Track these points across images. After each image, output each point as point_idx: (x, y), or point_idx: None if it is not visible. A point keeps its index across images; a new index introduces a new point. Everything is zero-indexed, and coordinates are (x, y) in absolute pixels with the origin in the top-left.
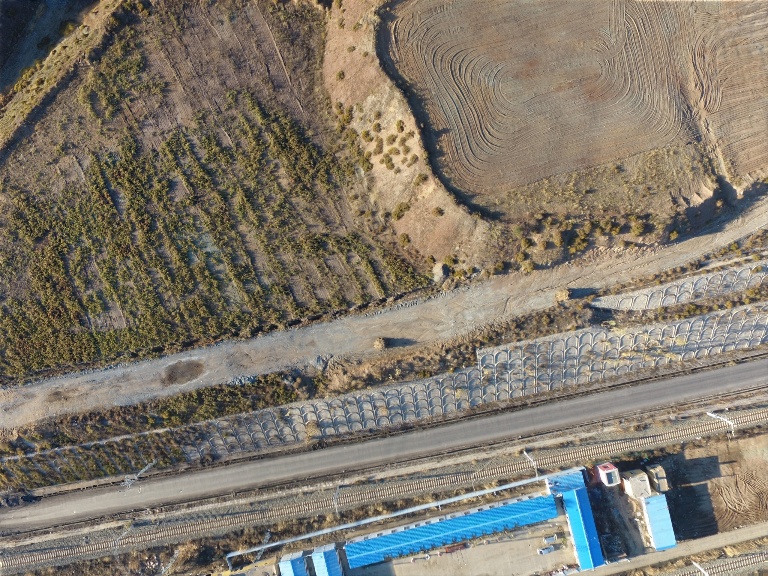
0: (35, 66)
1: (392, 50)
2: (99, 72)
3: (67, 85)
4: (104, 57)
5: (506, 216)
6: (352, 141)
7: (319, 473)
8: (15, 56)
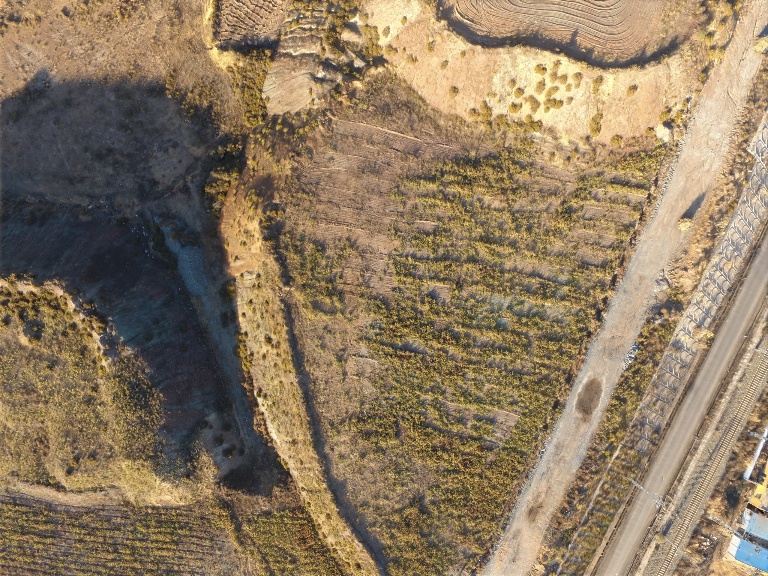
0: (239, 340)
1: (476, 30)
2: (300, 286)
3: (291, 319)
4: (292, 273)
5: (679, 37)
6: (506, 124)
7: (731, 357)
8: (218, 351)
